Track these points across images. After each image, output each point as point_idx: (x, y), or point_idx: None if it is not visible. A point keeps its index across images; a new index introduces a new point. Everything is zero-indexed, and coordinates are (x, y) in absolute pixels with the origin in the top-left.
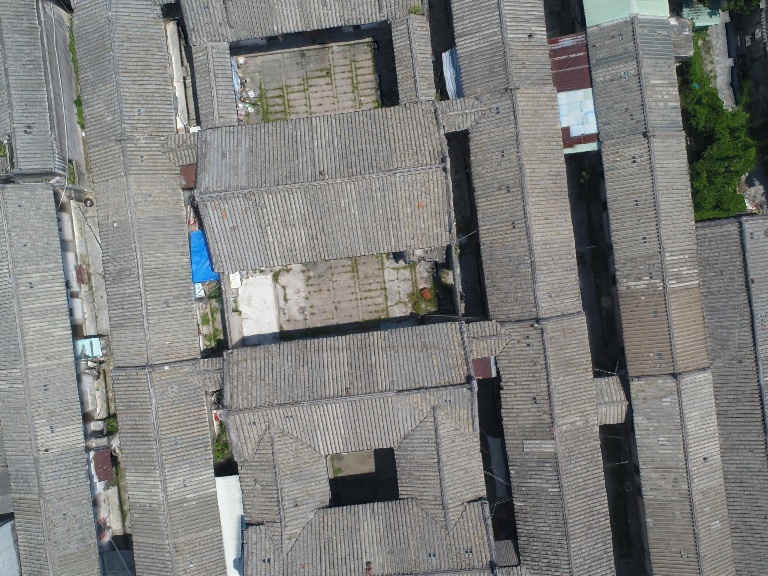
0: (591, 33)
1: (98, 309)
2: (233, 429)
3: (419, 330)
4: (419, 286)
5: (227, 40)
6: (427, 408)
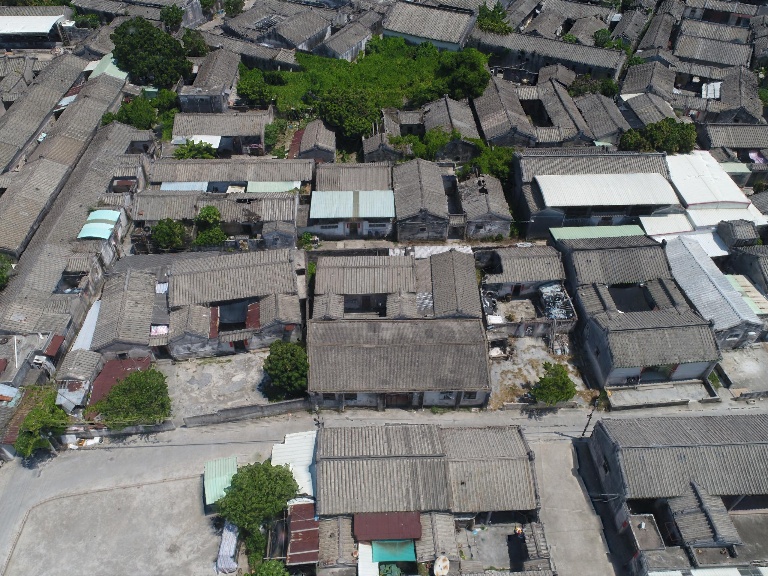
0: None
1: None
2: None
3: None
4: None
5: None
6: None
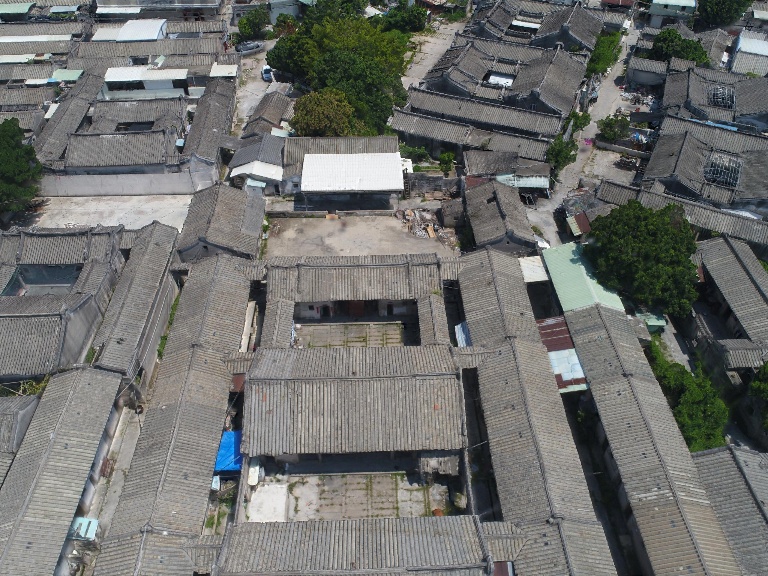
0: (568, 315)
1: (106, 503)
2: None
3: (432, 519)
4: (432, 507)
5: (294, 301)
6: None
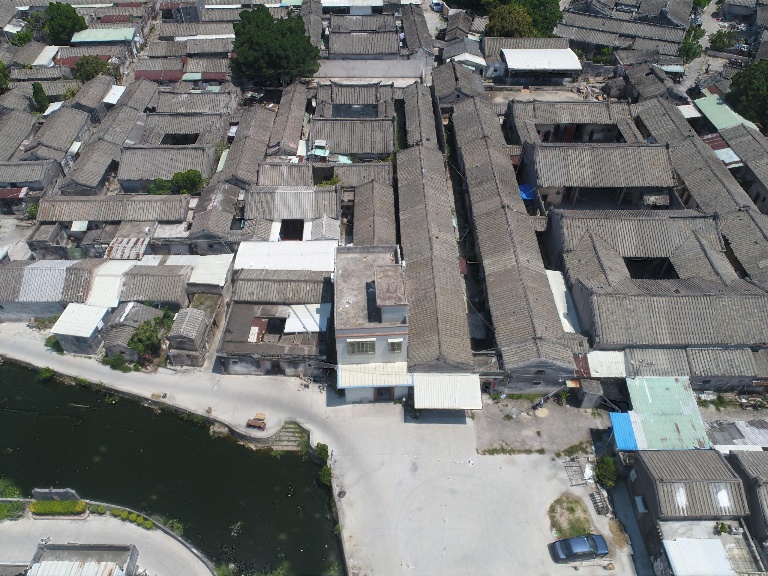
0: (721, 132)
1: None
2: (565, 228)
3: None
4: None
5: None
6: (688, 231)
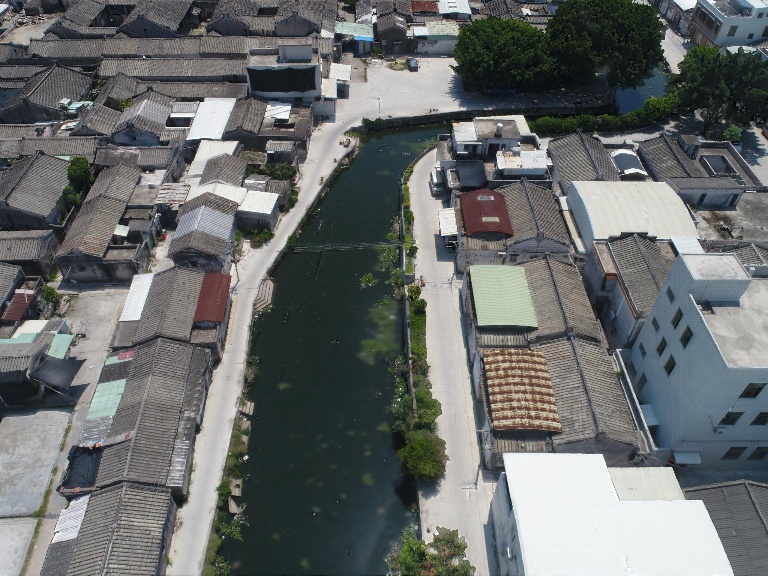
0: None
1: None
2: None
3: None
4: None
5: None
6: None
